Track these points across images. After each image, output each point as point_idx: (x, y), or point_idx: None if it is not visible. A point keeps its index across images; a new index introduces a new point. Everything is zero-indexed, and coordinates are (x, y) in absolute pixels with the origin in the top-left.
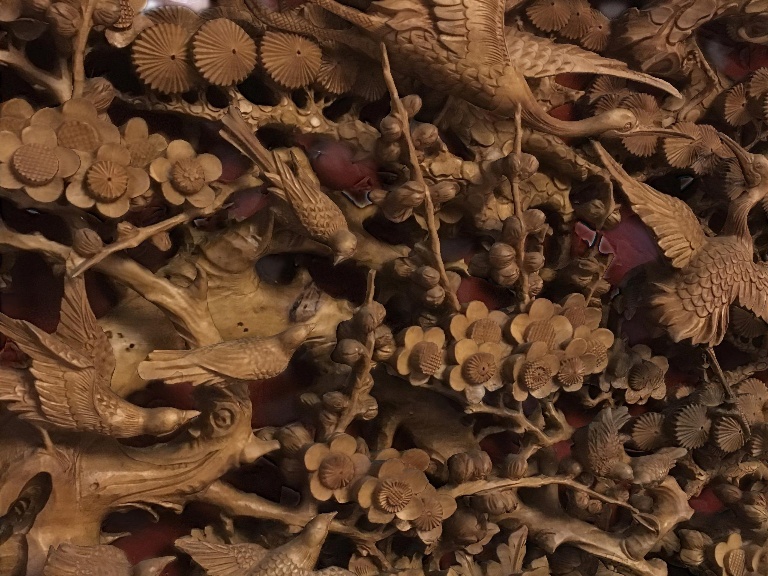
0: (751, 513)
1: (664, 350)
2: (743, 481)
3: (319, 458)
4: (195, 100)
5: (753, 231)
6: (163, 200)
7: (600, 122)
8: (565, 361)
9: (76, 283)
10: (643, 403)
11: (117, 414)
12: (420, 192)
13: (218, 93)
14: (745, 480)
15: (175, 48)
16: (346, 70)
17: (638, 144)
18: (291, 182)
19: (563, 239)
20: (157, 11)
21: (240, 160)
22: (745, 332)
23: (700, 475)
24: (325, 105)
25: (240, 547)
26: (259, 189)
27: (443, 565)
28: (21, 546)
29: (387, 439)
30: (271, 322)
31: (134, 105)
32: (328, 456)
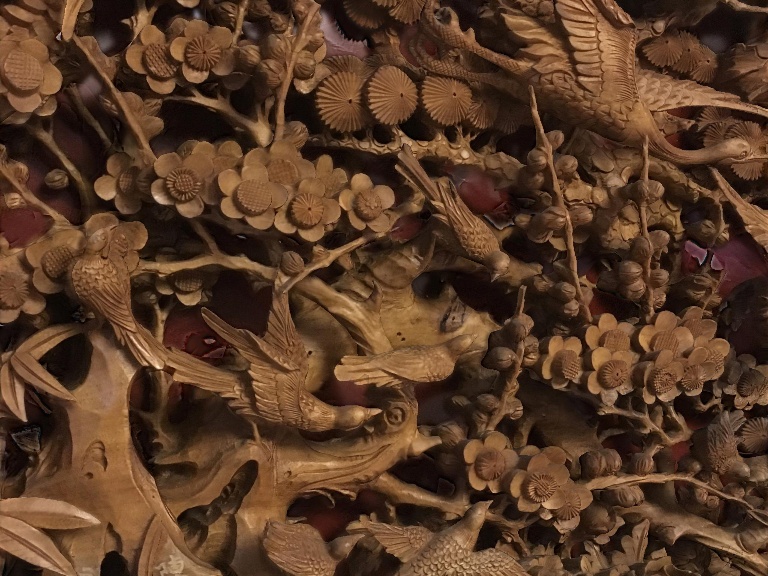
0: None
1: (767, 359)
2: None
3: (475, 453)
4: (363, 137)
5: None
6: (347, 226)
7: (718, 151)
8: (688, 368)
9: (282, 298)
10: (749, 409)
11: (314, 411)
12: (563, 216)
13: (382, 130)
14: None
15: (352, 93)
16: (490, 108)
17: (746, 169)
18: (453, 209)
19: (674, 256)
20: (331, 60)
21: (402, 189)
22: None
23: None
24: (471, 139)
25: (412, 529)
26: (419, 215)
27: (574, 554)
28: (229, 525)
29: (523, 438)
30: (425, 332)
31: (312, 142)
32: (483, 451)
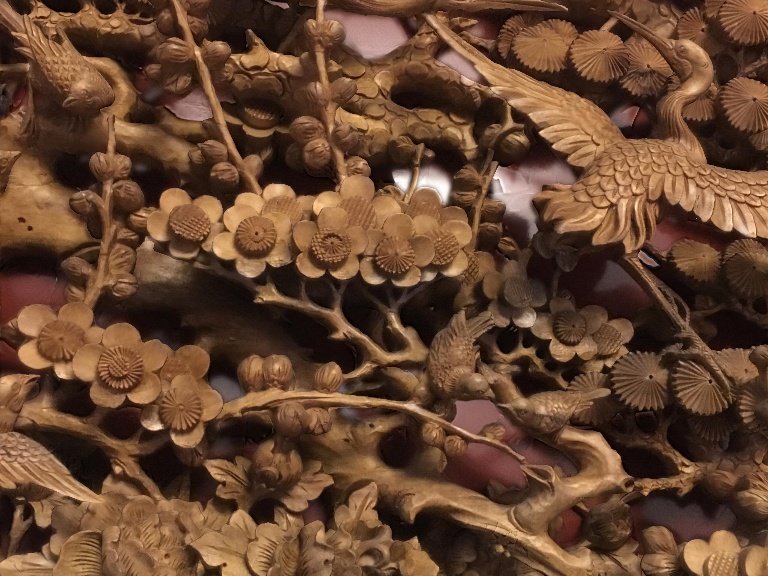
0: (745, 499)
1: (630, 315)
2: None
3: (42, 325)
4: None
5: (745, 170)
6: None
7: None
8: (382, 240)
9: None
10: None
11: None
12: (179, 44)
13: (25, 7)
14: None
15: None
16: None
17: (537, 58)
18: (37, 39)
19: None
20: None
21: None
22: (745, 287)
23: (684, 466)
24: (141, 19)
25: None
26: None
27: None
28: None
29: None
30: (59, 221)
31: None
32: None
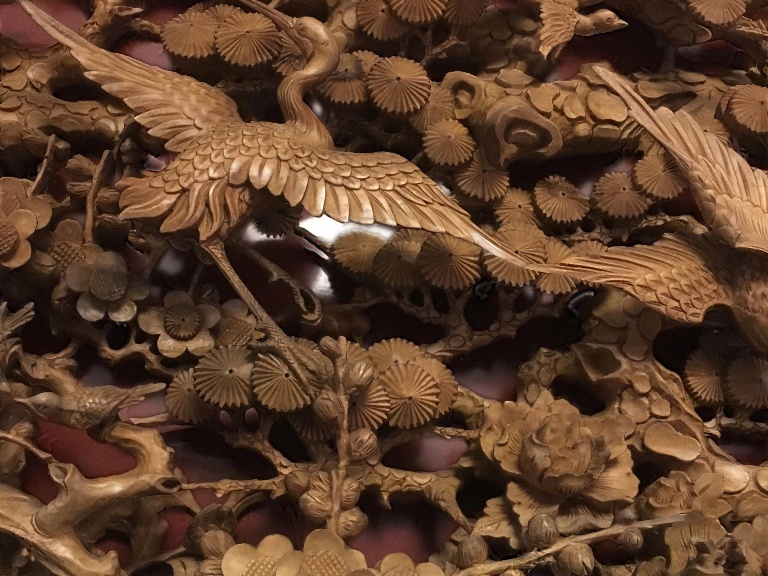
0: (301, 501)
1: (274, 309)
2: (426, 511)
3: None
4: None
5: (412, 155)
6: None
7: None
8: None
9: None
10: None
11: None
12: None
13: None
14: (426, 508)
15: None
16: None
17: (183, 44)
18: None
19: (123, 173)
20: None
21: None
22: (389, 278)
23: (282, 466)
24: None
25: None
26: None
27: None
28: None
29: None
30: None
31: None
32: None
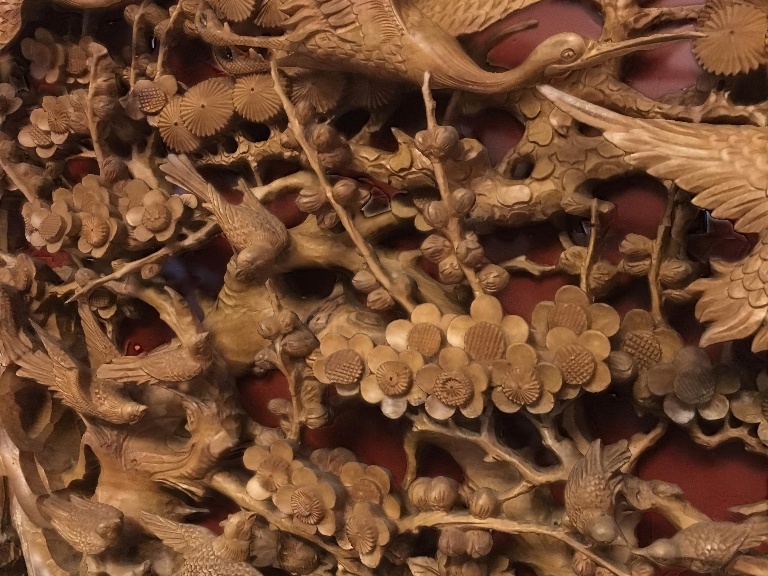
0: None
1: None
2: None
3: (261, 460)
4: (217, 151)
5: None
6: None
7: (530, 61)
8: None
9: (84, 308)
10: None
11: None
12: (308, 196)
13: None
14: None
15: (178, 116)
16: (325, 88)
17: (725, 58)
18: (218, 208)
19: (675, 213)
20: None
21: None
22: None
23: None
24: None
25: (189, 527)
26: None
27: None
28: None
29: (408, 457)
30: None
31: None
32: None
